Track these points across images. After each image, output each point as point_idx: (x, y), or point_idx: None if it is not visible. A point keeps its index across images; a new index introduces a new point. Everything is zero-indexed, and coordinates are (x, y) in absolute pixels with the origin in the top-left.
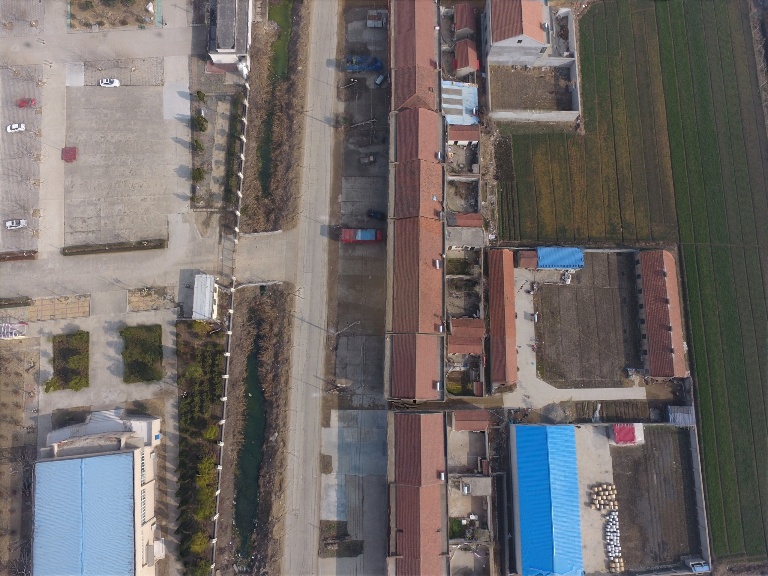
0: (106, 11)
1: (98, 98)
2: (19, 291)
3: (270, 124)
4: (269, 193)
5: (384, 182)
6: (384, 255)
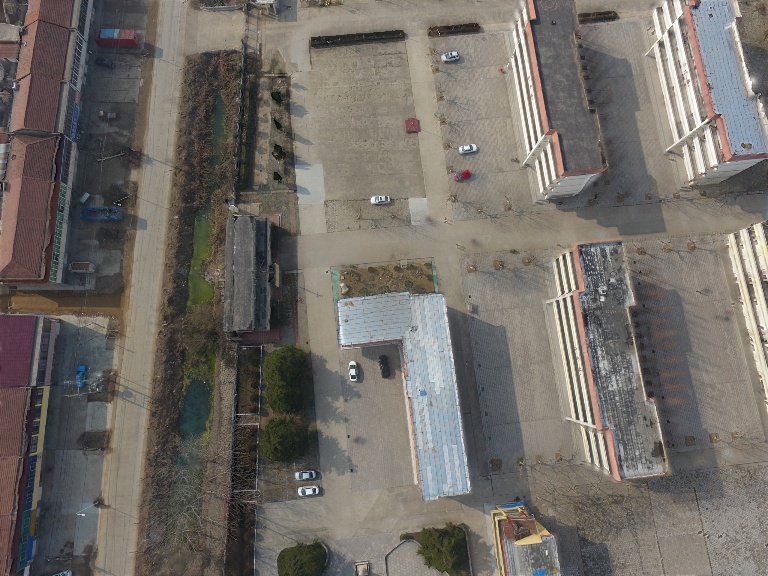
0: (395, 286)
1: (392, 185)
2: (439, 3)
3: (213, 162)
4: (214, 92)
5: (95, 96)
6: (101, 27)
